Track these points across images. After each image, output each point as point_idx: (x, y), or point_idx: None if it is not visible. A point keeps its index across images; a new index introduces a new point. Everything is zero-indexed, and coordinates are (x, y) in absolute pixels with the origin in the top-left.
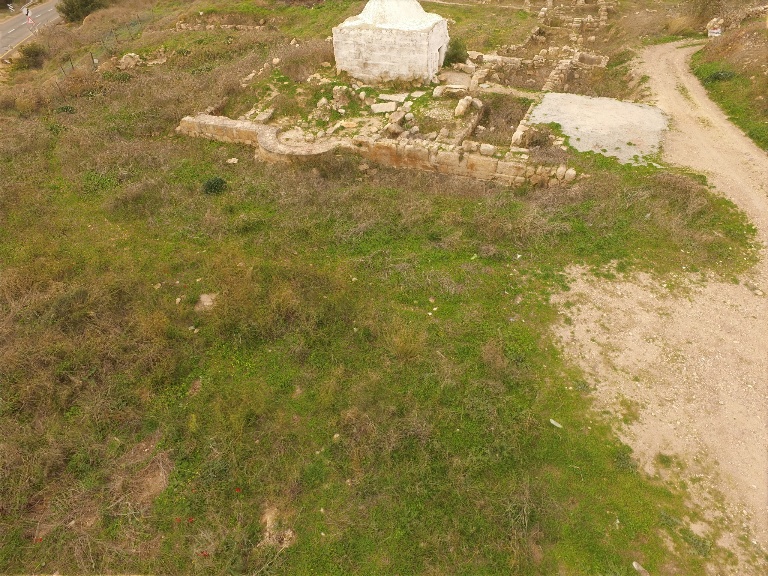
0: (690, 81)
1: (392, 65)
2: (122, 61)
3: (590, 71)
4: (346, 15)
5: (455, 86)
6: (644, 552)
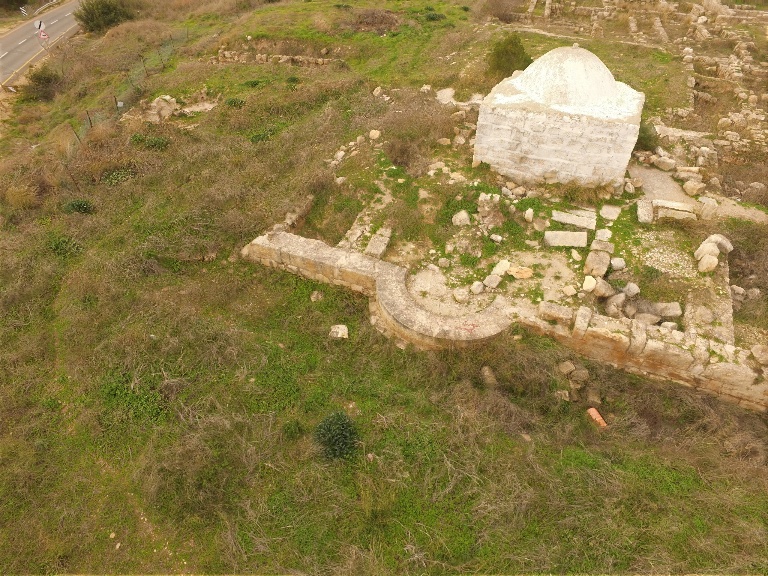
0: None
1: (567, 164)
2: (153, 105)
3: None
4: (432, 48)
5: (671, 204)
6: None
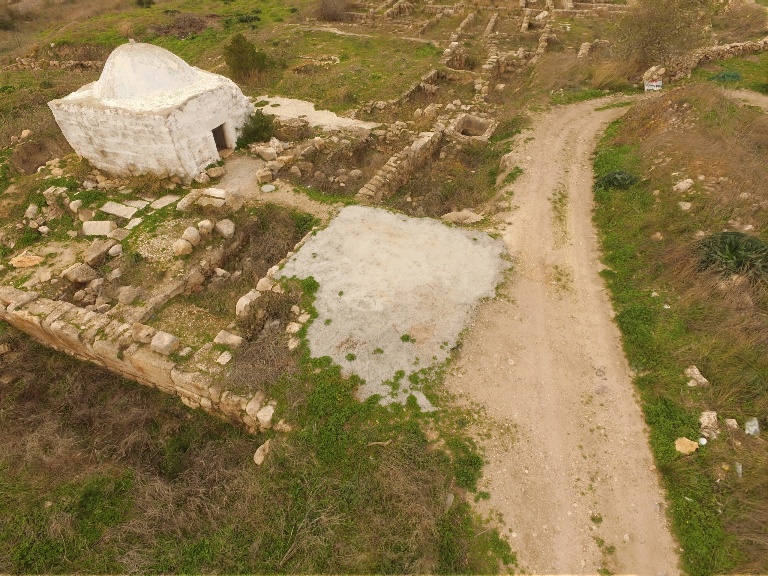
0: (581, 179)
1: (135, 156)
2: None
3: (463, 147)
4: (213, 50)
5: (215, 192)
6: None
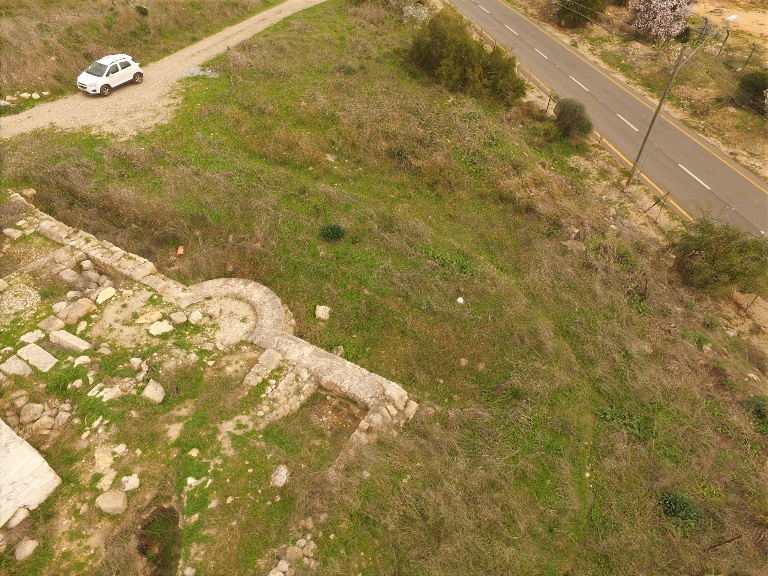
0: None
1: None
2: None
3: None
4: None
5: None
6: None
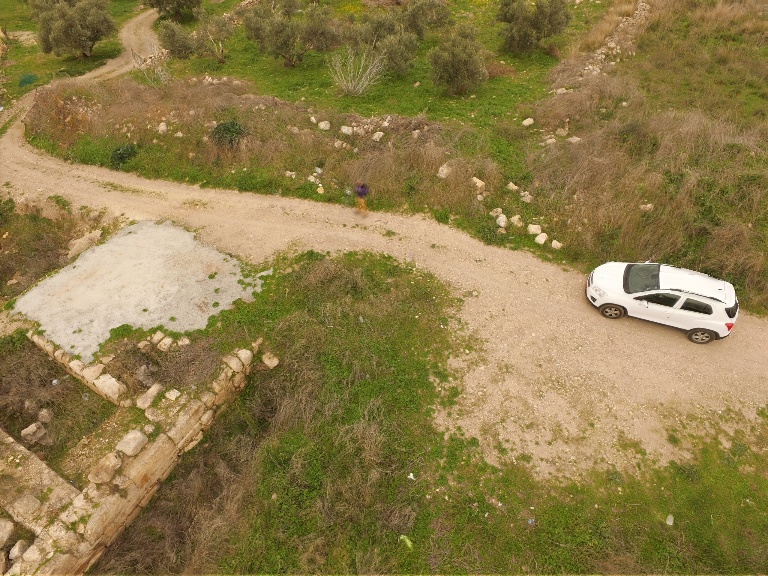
0: (96, 173)
1: None
2: None
3: None
4: None
5: None
6: (765, 491)
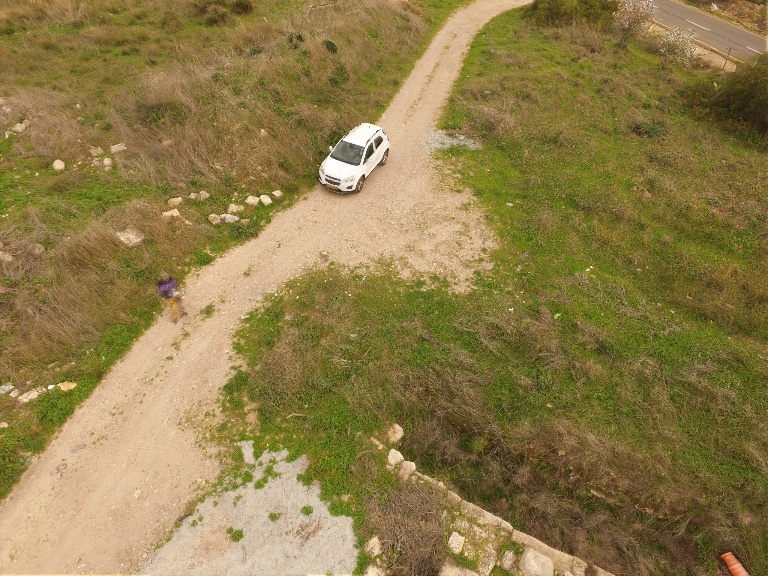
0: None
1: None
2: None
3: None
4: None
5: None
6: None
